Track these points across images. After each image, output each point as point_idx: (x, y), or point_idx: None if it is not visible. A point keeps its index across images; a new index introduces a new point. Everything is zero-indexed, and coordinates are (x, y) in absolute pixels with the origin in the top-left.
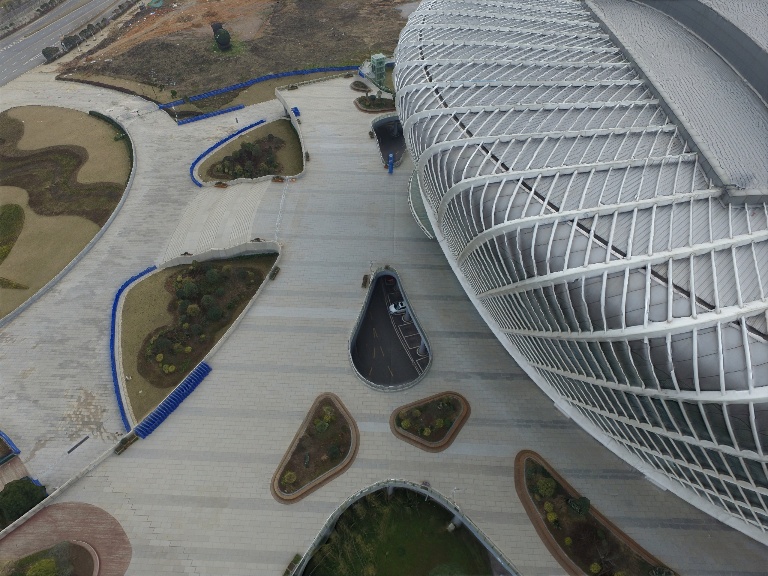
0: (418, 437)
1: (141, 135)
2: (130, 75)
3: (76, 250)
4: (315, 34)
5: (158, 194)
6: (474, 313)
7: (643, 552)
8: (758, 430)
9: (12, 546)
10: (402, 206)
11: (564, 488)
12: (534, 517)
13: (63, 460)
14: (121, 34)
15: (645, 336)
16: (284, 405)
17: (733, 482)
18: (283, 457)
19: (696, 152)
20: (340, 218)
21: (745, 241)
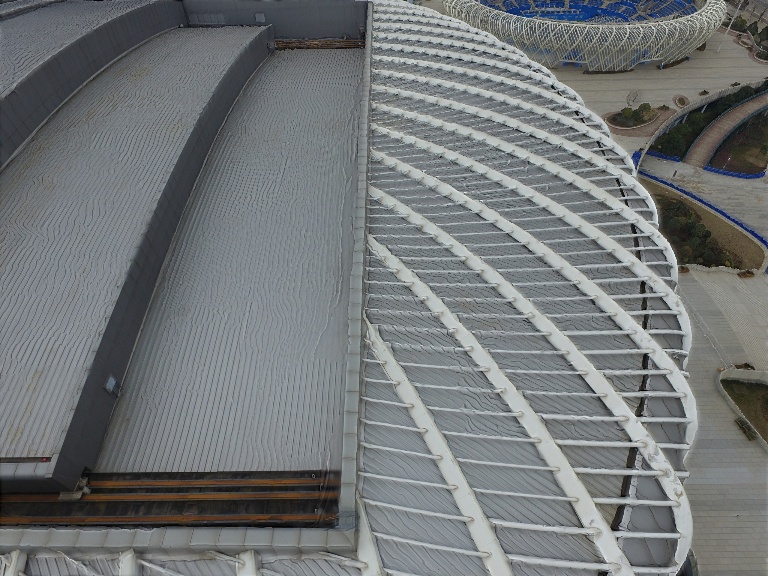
0: None
1: None
2: None
3: None
4: None
5: None
6: None
7: None
8: None
9: (653, 127)
10: None
11: None
12: None
13: (675, 168)
14: None
15: None
16: None
17: None
18: None
19: None
20: None
21: None
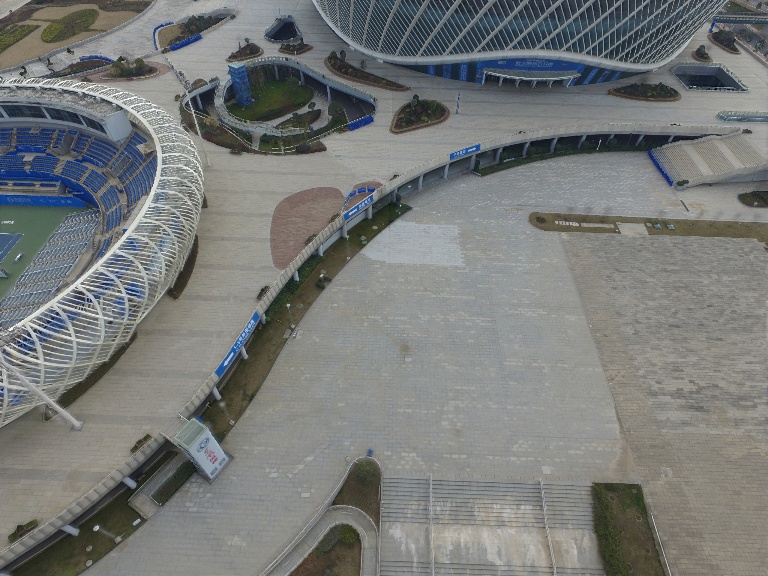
0: (288, 51)
1: None
2: None
3: None
4: None
5: (172, 3)
6: (326, 29)
7: None
8: None
9: None
10: (303, 1)
11: None
12: (327, 66)
13: None
14: None
15: None
16: (233, 46)
17: (370, 7)
18: None
19: None
20: (270, 4)
21: None
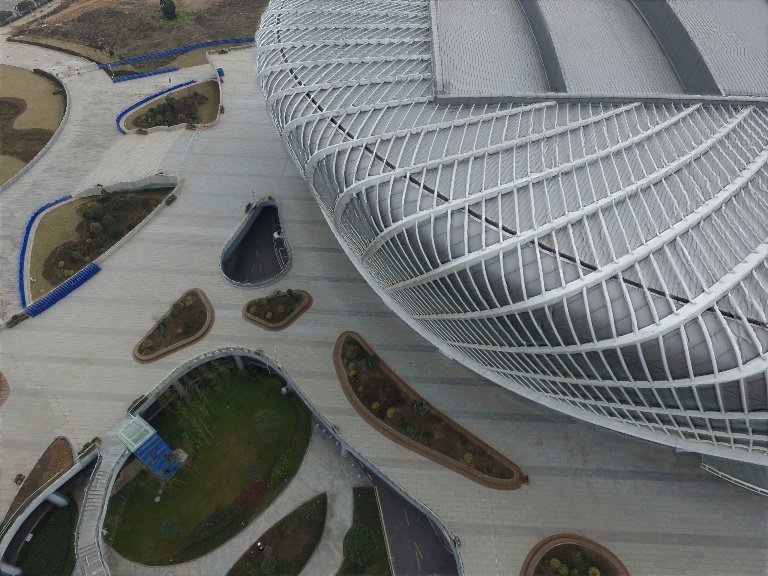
0: (262, 320)
1: (78, 90)
2: (78, 39)
3: (3, 183)
4: (260, 8)
5: (84, 139)
6: None
7: (419, 398)
8: (414, 250)
9: None
10: None
11: (370, 356)
12: (341, 375)
13: None
14: (74, 1)
15: (354, 191)
16: (157, 296)
17: (446, 317)
18: (148, 332)
19: (434, 72)
20: (240, 160)
21: (433, 126)
